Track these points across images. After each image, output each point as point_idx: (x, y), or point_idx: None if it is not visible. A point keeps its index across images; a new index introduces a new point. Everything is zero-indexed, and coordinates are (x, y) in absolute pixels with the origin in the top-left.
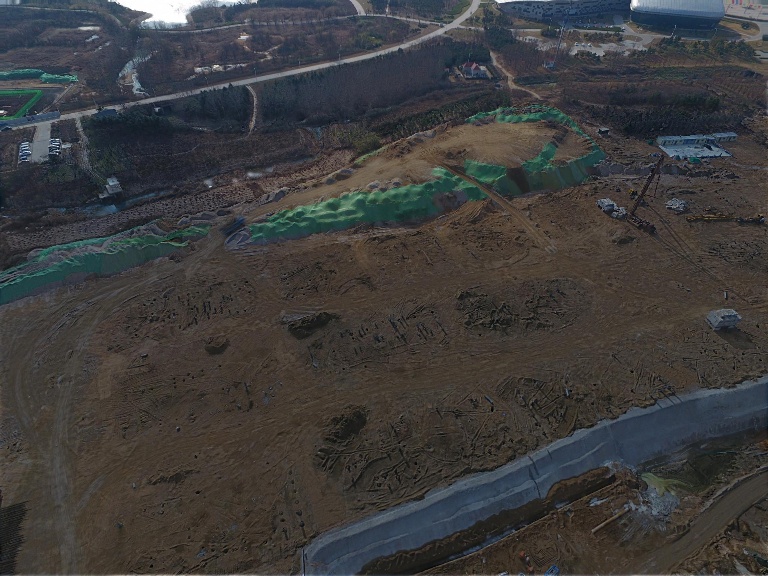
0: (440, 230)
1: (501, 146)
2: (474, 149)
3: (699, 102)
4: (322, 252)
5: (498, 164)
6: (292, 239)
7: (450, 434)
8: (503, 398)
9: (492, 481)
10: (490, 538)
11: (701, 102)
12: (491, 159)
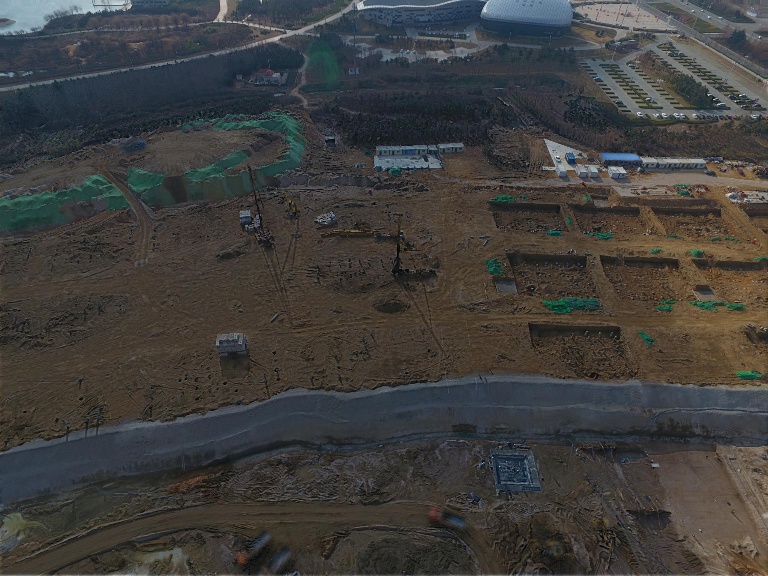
0: (48, 240)
1: (185, 154)
2: (154, 156)
3: (457, 111)
4: None
5: (160, 172)
6: None
7: None
8: None
9: None
10: None
11: (462, 111)
12: (159, 167)
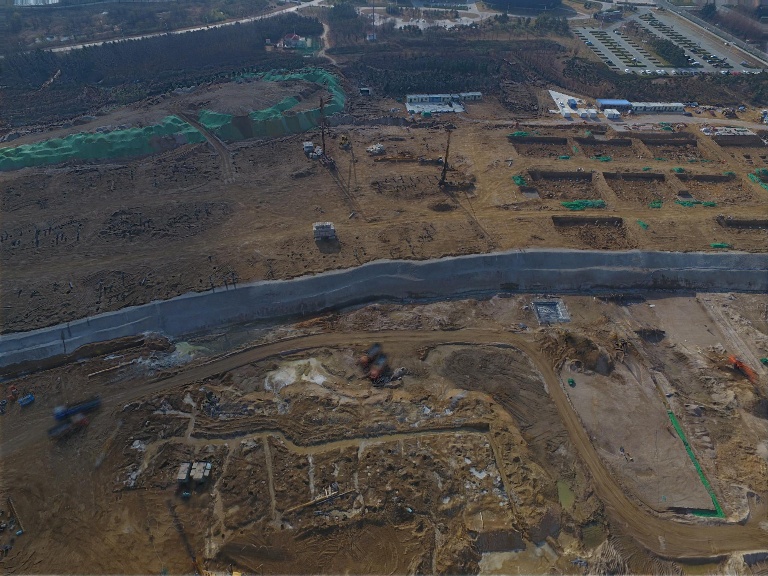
0: (144, 166)
1: (245, 99)
2: (218, 101)
3: (471, 67)
4: (22, 181)
5: (228, 113)
6: (3, 171)
7: (15, 307)
8: (84, 284)
9: (20, 338)
10: (3, 380)
11: (476, 68)
12: (225, 109)
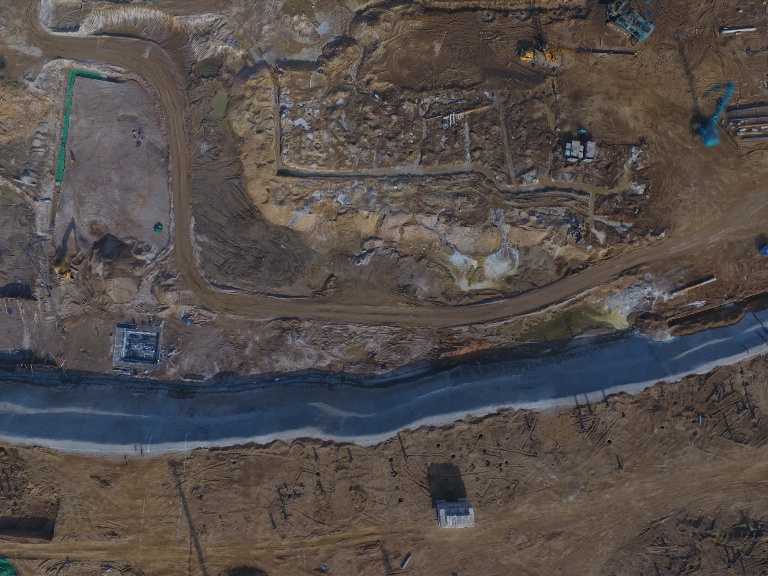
0: None
1: None
2: None
3: None
4: None
5: None
6: None
7: None
8: None
9: None
10: None
11: None
12: None
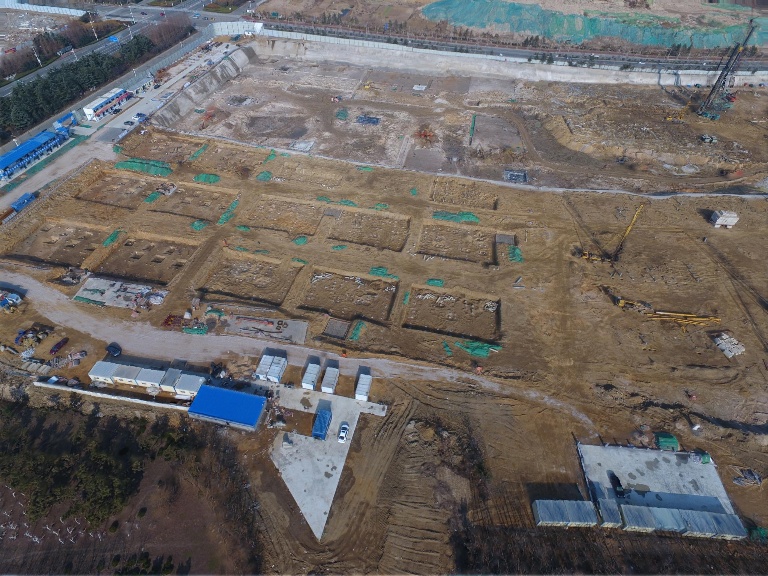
0: None
1: None
2: None
3: None
4: None
5: None
6: None
7: None
8: None
9: None
10: None
11: None
12: None
